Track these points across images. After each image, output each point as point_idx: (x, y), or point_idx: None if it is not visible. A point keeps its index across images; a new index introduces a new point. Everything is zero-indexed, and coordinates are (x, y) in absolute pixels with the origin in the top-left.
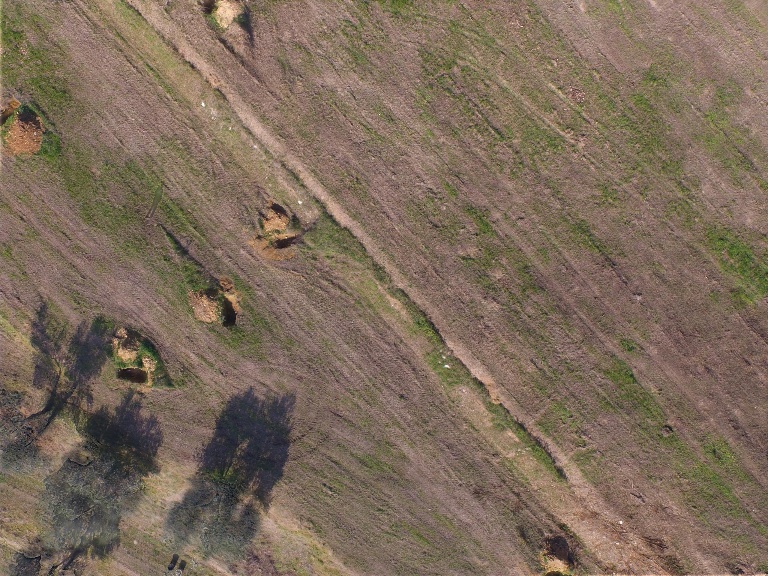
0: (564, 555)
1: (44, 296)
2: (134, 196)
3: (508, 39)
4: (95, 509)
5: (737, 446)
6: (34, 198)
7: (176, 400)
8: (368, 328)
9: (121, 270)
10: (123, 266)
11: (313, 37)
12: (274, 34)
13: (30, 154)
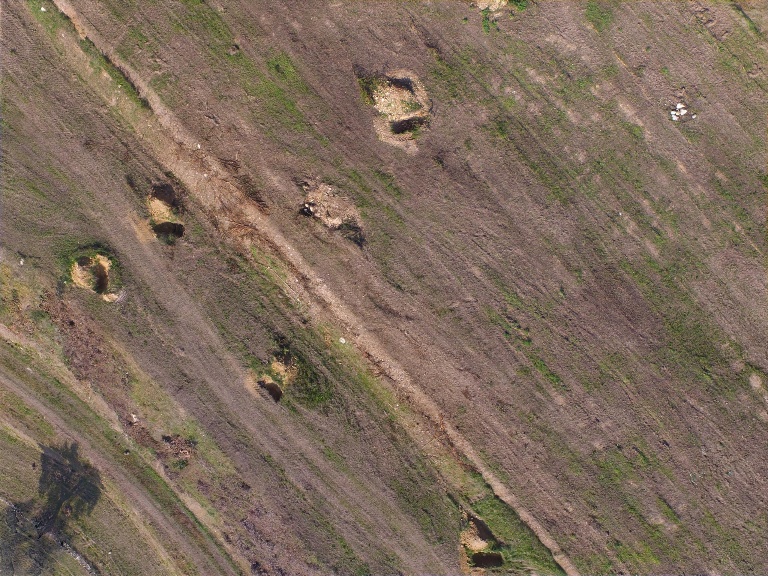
0: (168, 199)
1: None
2: None
3: None
4: None
5: (297, 59)
6: None
7: None
8: None
9: None
10: None
11: None
12: None
13: None
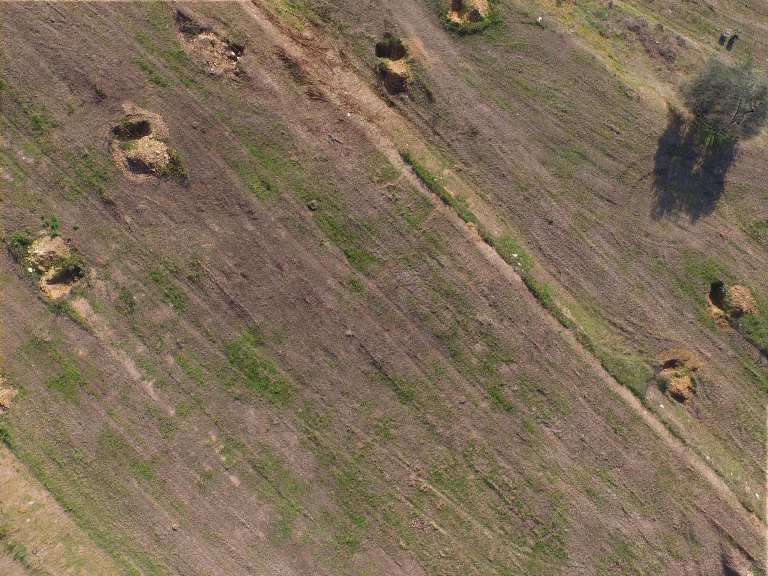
0: (390, 78)
1: None
2: None
3: (486, 574)
4: None
5: (248, 195)
6: None
7: (763, 208)
8: (586, 287)
9: None
10: None
11: (666, 567)
12: (703, 568)
13: None
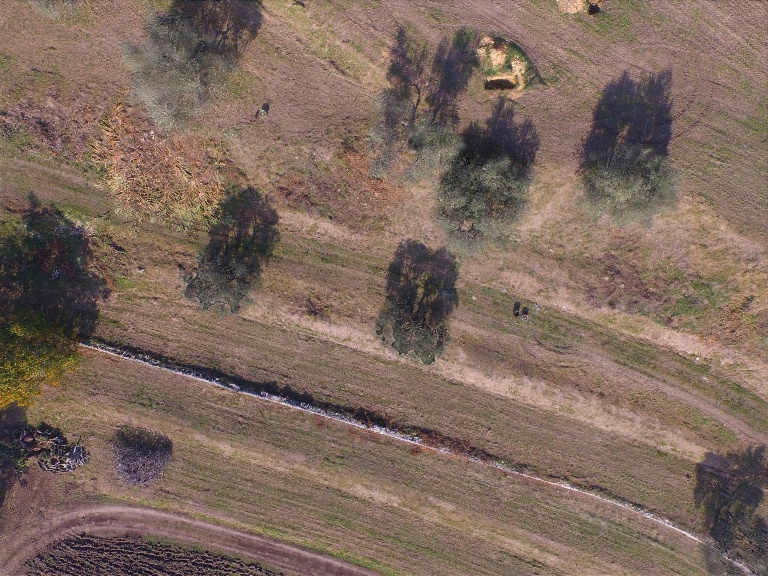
0: None
1: (399, 21)
2: None
3: None
4: (429, 272)
5: None
6: None
7: (550, 99)
8: None
9: None
10: None
11: None
12: None
13: None
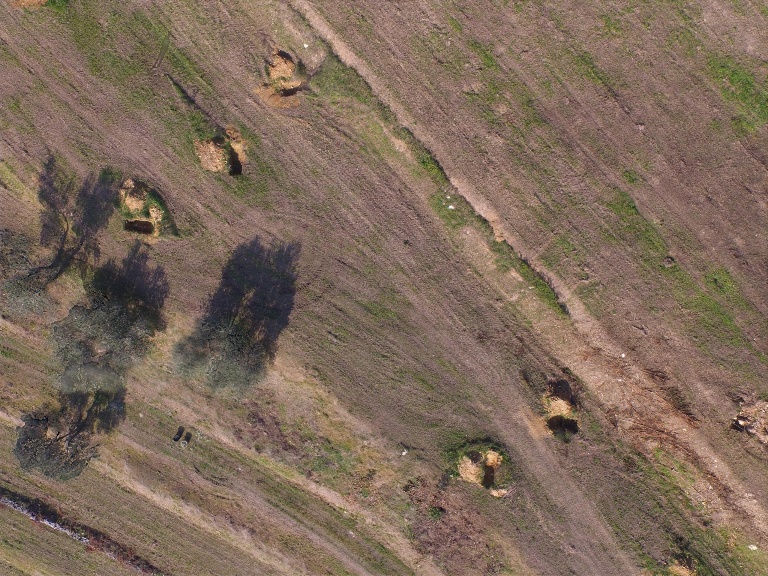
0: (567, 397)
1: (52, 149)
2: (141, 46)
3: None
4: (101, 383)
5: (738, 275)
6: (42, 50)
7: (183, 250)
8: (373, 175)
9: (128, 121)
10: (130, 117)
11: None
12: None
13: (38, 6)
